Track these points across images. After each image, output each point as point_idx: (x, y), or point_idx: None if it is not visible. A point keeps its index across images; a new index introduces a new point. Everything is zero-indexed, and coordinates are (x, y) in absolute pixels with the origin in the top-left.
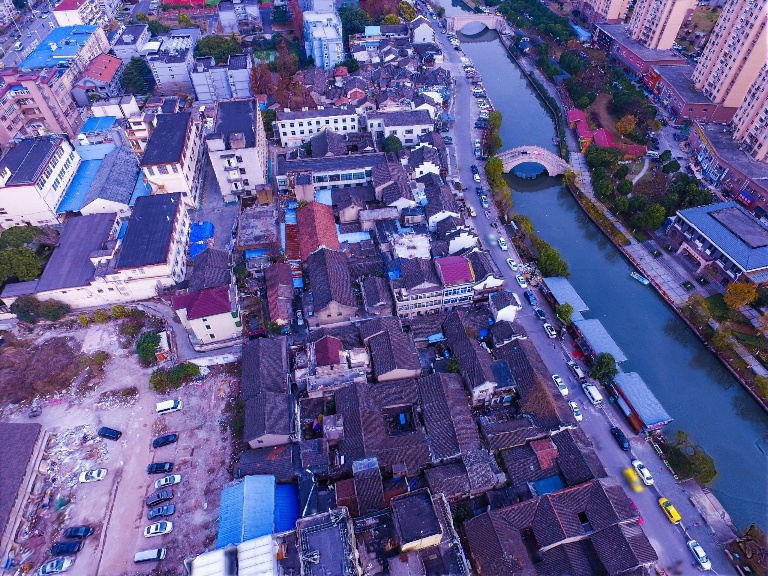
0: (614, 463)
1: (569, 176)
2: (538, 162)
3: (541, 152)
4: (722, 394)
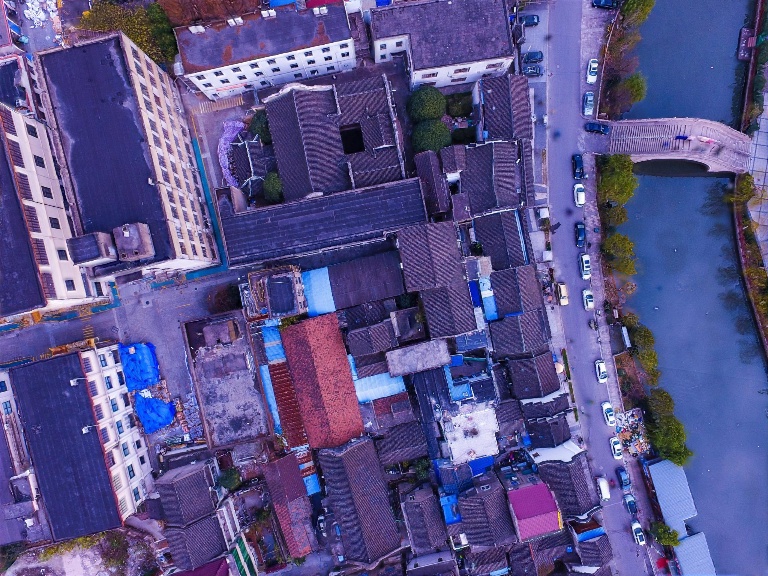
0: None
1: None
2: (700, 161)
3: (713, 131)
4: None
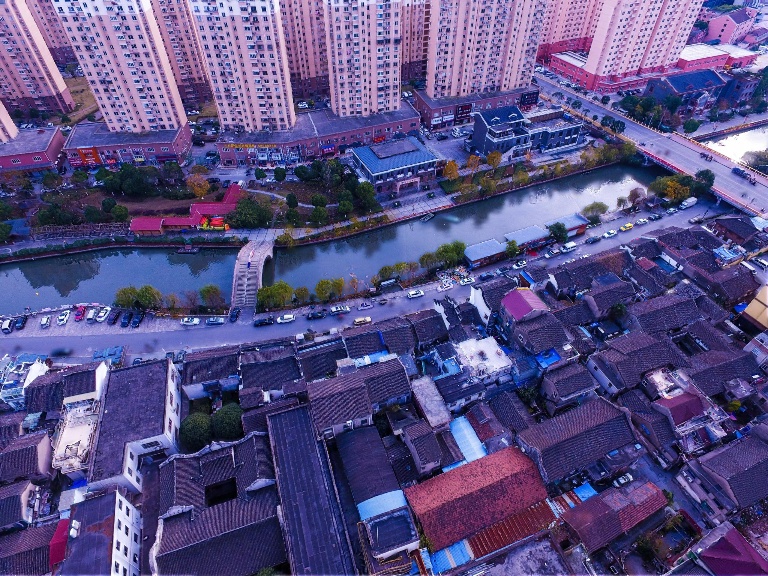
0: (612, 245)
1: (282, 241)
2: (265, 257)
3: (246, 252)
4: (507, 207)
